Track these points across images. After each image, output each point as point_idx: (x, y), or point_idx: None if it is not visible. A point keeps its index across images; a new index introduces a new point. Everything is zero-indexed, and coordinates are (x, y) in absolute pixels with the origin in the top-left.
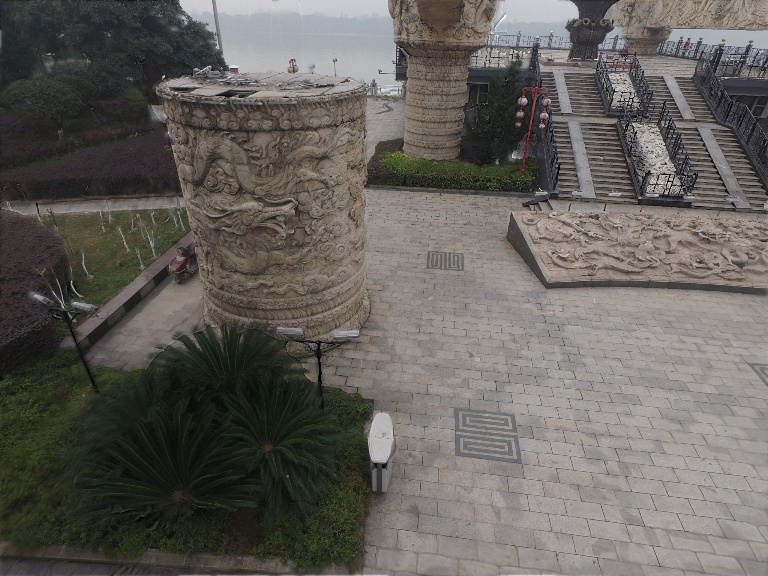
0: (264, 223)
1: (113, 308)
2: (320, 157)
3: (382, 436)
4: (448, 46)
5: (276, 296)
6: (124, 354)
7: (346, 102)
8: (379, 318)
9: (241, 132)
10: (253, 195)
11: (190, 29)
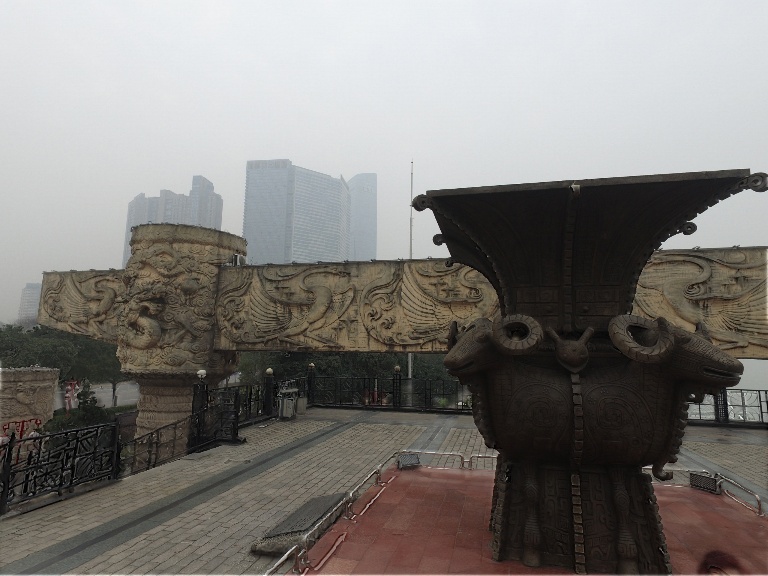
0: None
1: None
2: None
3: None
4: None
5: None
6: None
7: None
8: None
9: None
10: None
11: None
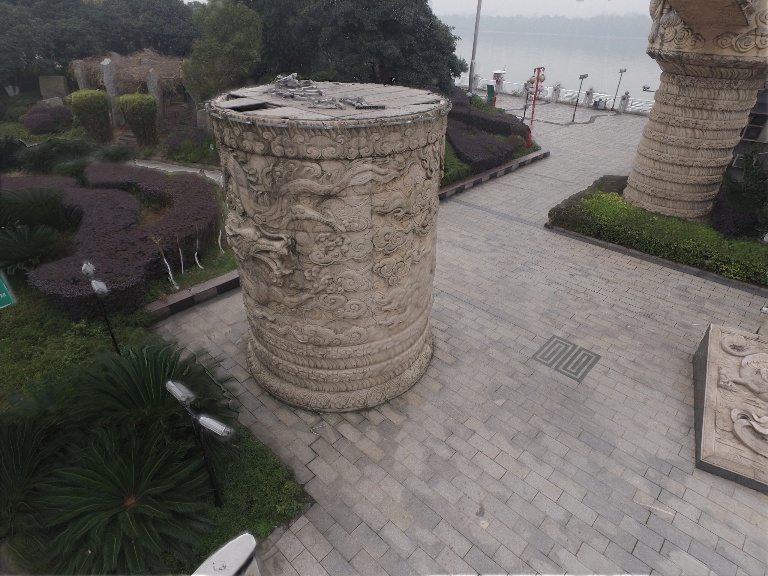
0: (259, 255)
1: (206, 287)
2: (323, 195)
3: (219, 568)
4: (718, 61)
5: (278, 334)
6: (183, 332)
7: (367, 132)
8: (415, 399)
9: (241, 151)
10: (253, 222)
11: (430, 32)
